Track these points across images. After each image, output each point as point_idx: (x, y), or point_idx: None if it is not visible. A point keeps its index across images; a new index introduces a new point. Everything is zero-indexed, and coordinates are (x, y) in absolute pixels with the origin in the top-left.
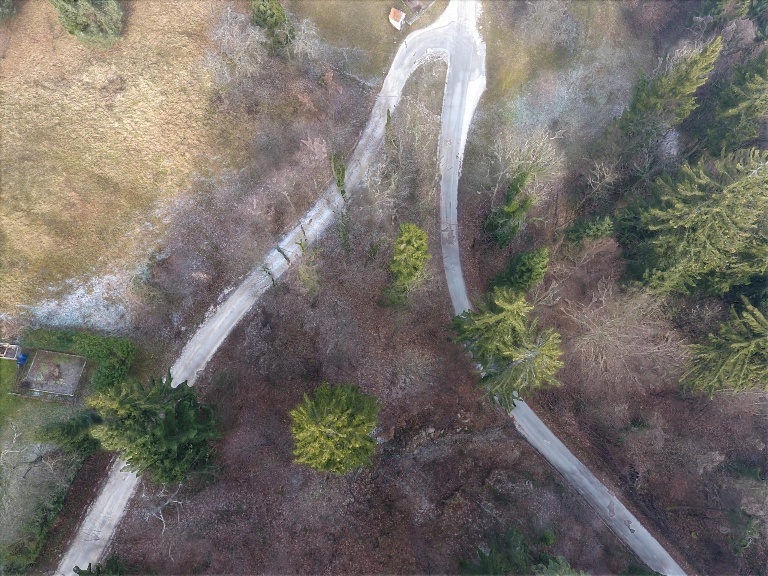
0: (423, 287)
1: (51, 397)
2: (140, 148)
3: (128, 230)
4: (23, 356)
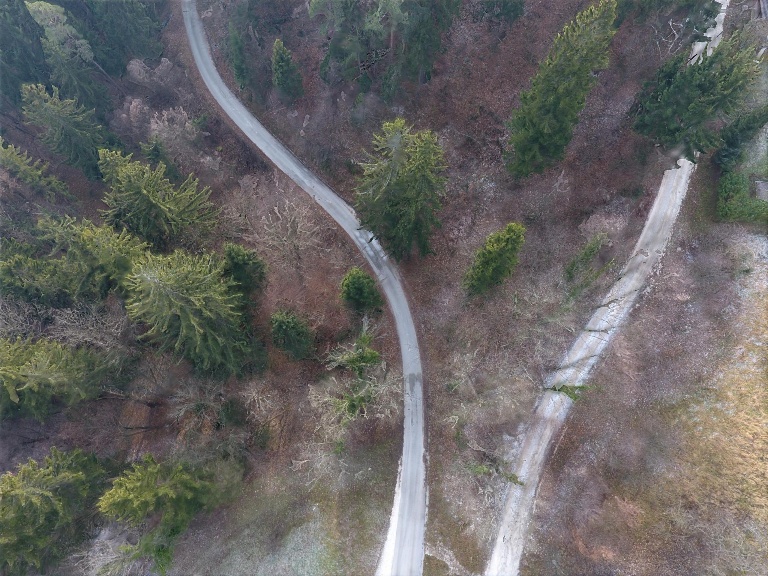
0: (443, 320)
1: None
2: None
3: None
4: None
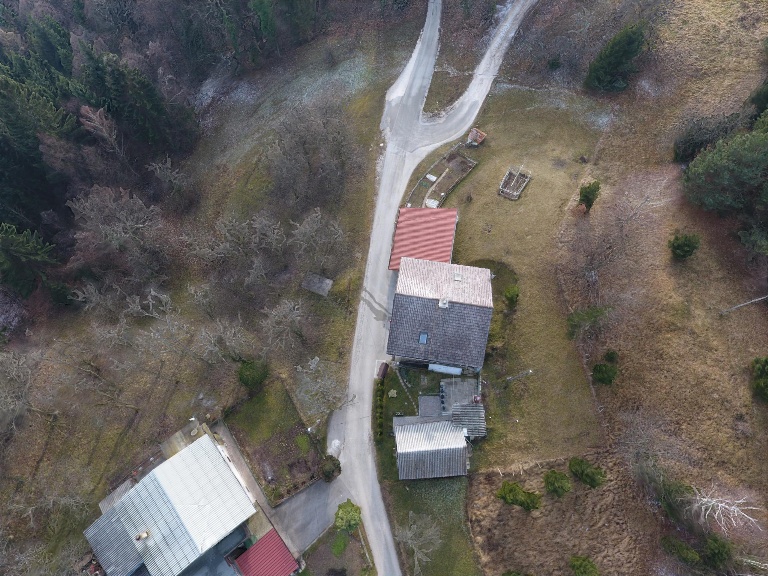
0: None
1: None
2: None
3: None
4: None
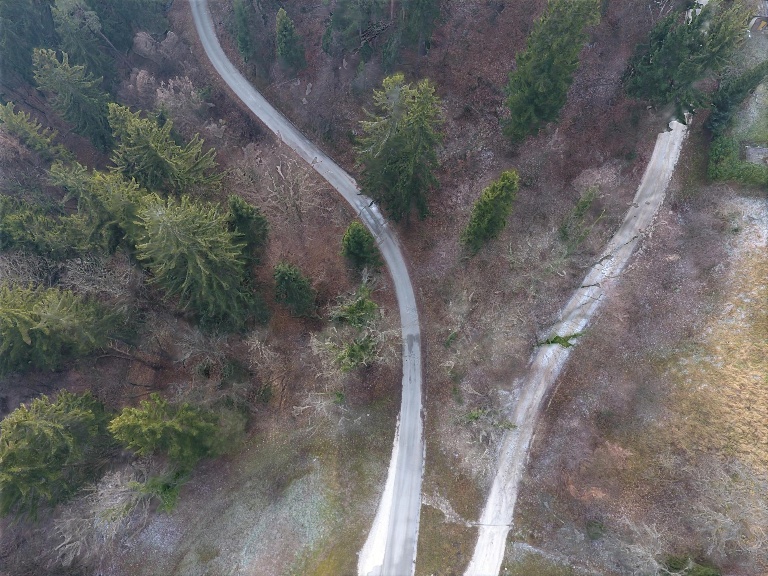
0: (441, 283)
1: (763, 145)
2: None
3: (764, 291)
4: None
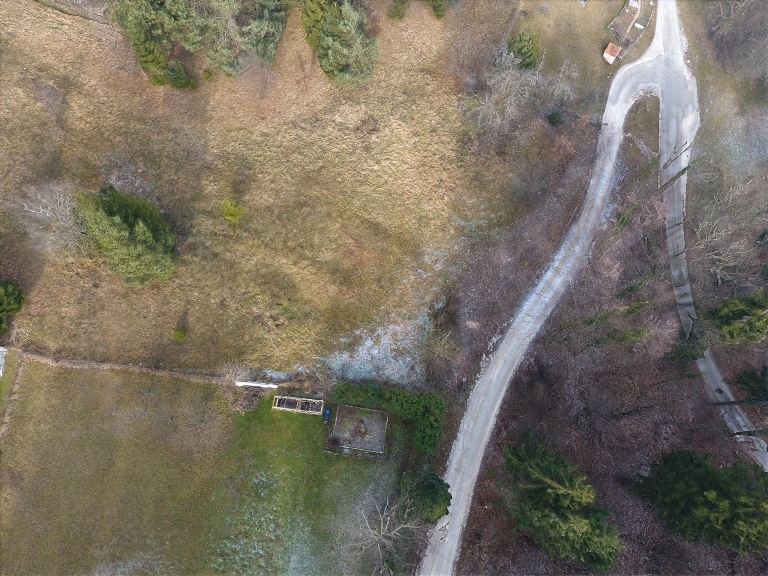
0: None
1: (362, 454)
2: (401, 191)
3: (403, 278)
4: (329, 411)
